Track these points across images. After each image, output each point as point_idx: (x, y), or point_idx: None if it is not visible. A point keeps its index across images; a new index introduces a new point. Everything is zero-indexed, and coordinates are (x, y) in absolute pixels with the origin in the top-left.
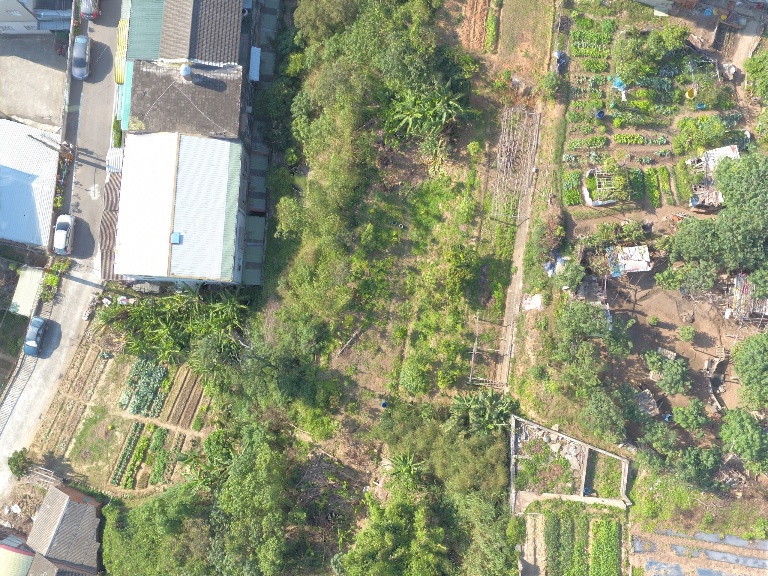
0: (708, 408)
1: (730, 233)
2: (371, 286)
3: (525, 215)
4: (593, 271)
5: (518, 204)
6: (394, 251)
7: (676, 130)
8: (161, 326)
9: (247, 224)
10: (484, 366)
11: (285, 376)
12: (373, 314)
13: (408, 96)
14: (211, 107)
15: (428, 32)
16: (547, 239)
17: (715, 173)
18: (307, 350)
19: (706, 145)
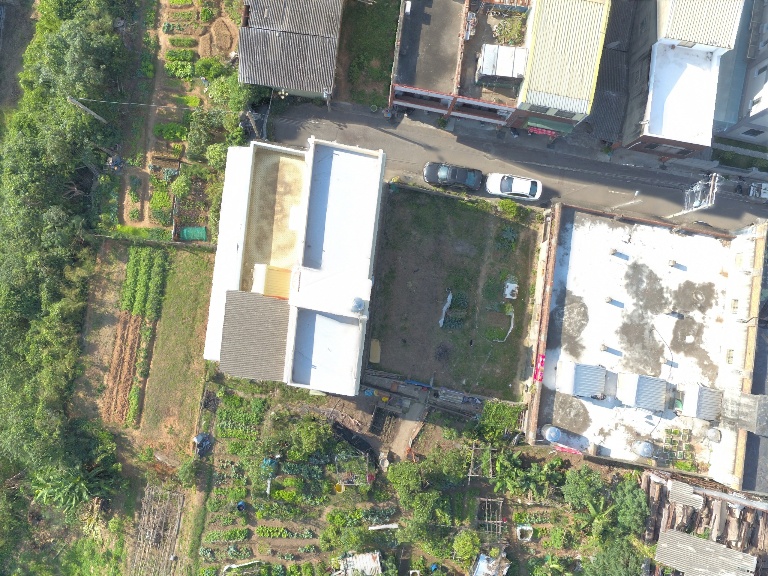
0: None
1: None
2: None
3: None
4: None
5: None
6: None
7: (325, 522)
8: None
9: None
10: None
11: None
12: None
13: None
14: None
15: (52, 416)
16: None
17: None
18: None
19: None
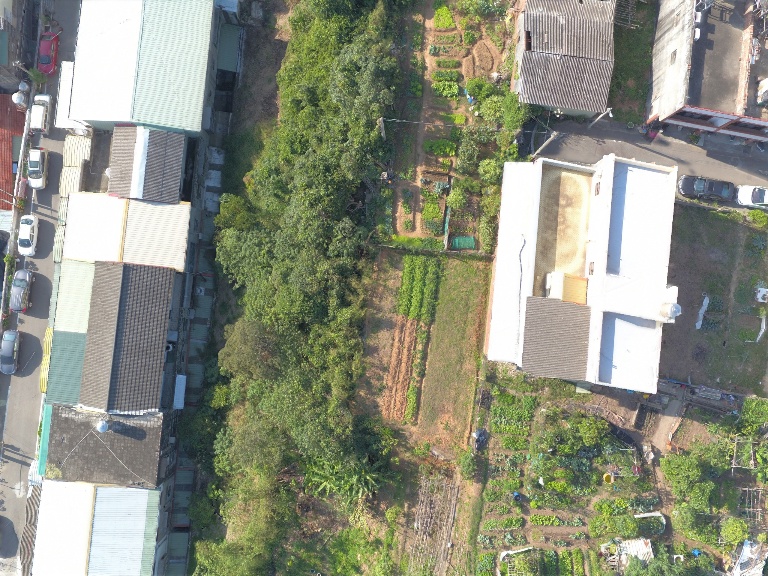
0: None
1: None
2: None
3: None
4: None
5: None
6: None
7: (593, 511)
8: None
9: (170, 541)
10: None
11: None
12: None
13: None
14: (130, 456)
15: (346, 414)
16: None
17: (626, 571)
18: None
19: None
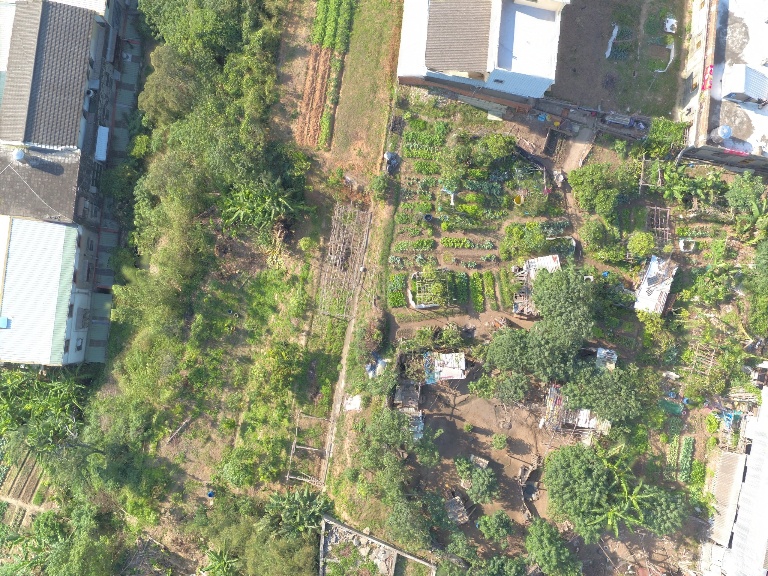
0: (520, 515)
1: (537, 348)
2: (203, 375)
3: (352, 313)
4: (408, 377)
5: (345, 302)
6: (228, 340)
7: (504, 235)
8: (2, 401)
9: (93, 301)
10: (308, 461)
11: (112, 463)
12: (204, 403)
13: (243, 188)
14: (47, 190)
15: (257, 130)
16: (366, 342)
17: None
18: (135, 438)
19: (533, 251)
